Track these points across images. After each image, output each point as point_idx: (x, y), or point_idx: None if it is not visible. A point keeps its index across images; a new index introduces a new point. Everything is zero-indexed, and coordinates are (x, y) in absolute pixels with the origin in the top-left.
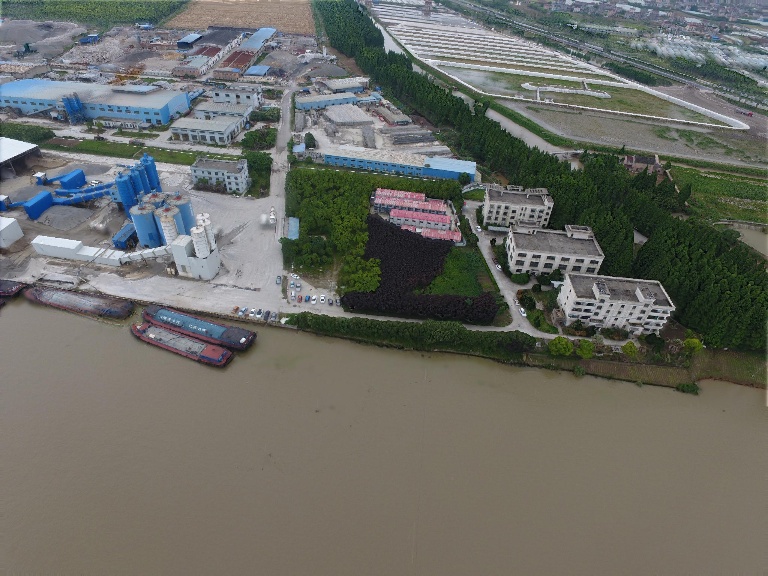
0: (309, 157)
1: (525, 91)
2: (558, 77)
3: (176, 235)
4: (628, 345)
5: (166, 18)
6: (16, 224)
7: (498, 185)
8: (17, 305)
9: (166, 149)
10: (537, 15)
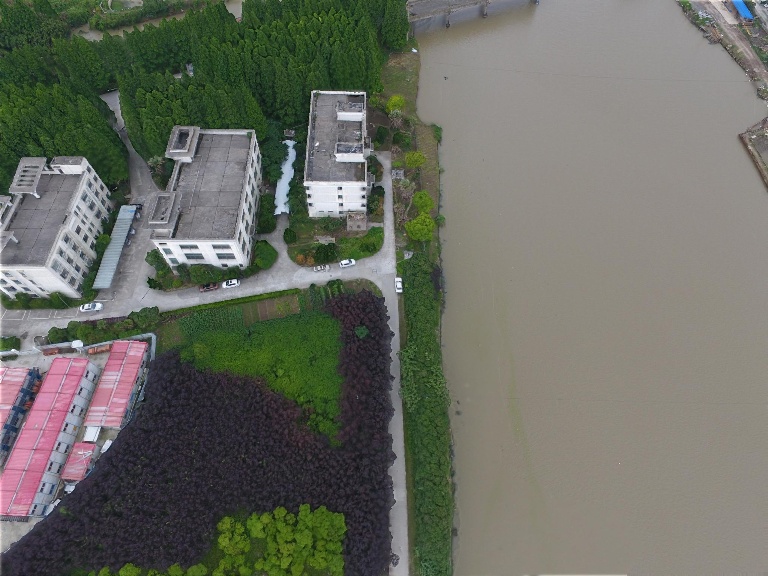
0: None
1: None
2: None
3: None
4: (417, 157)
5: None
6: None
7: None
8: None
9: None
10: None
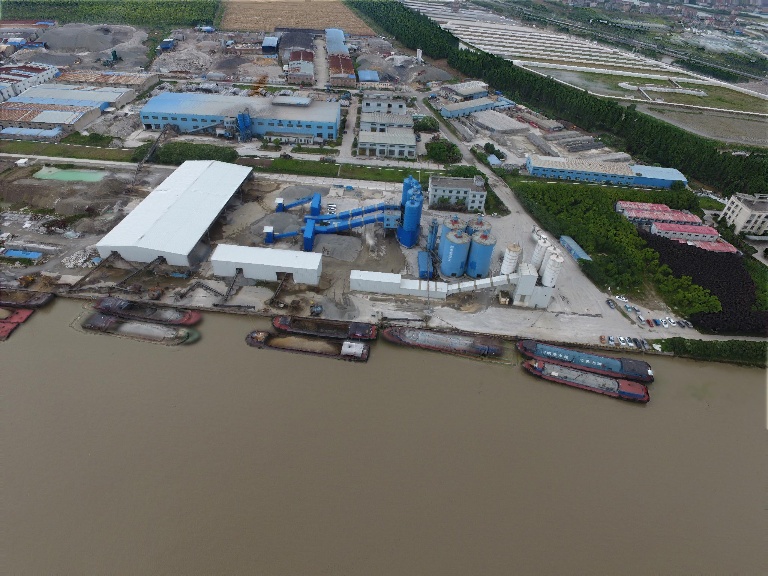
0: (517, 169)
1: (628, 91)
2: (644, 76)
3: (516, 264)
4: None
5: (214, 19)
6: (321, 259)
7: (747, 194)
8: (382, 349)
9: (363, 166)
10: (562, 11)
